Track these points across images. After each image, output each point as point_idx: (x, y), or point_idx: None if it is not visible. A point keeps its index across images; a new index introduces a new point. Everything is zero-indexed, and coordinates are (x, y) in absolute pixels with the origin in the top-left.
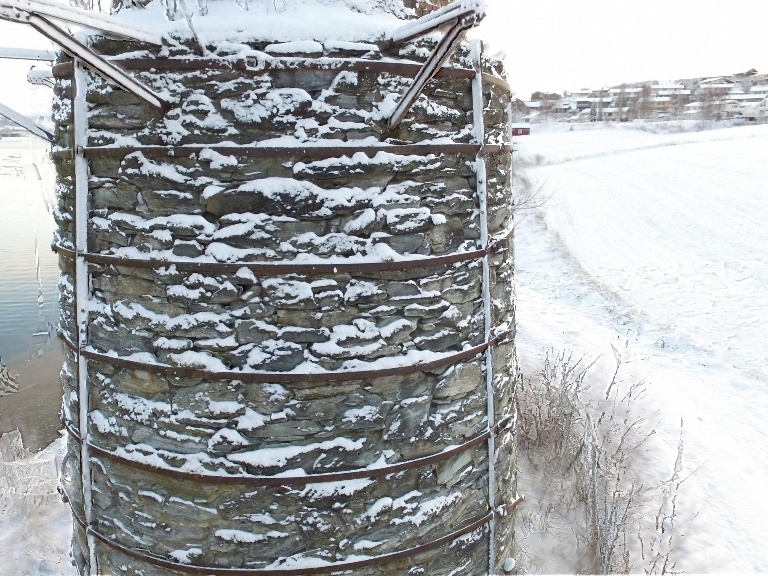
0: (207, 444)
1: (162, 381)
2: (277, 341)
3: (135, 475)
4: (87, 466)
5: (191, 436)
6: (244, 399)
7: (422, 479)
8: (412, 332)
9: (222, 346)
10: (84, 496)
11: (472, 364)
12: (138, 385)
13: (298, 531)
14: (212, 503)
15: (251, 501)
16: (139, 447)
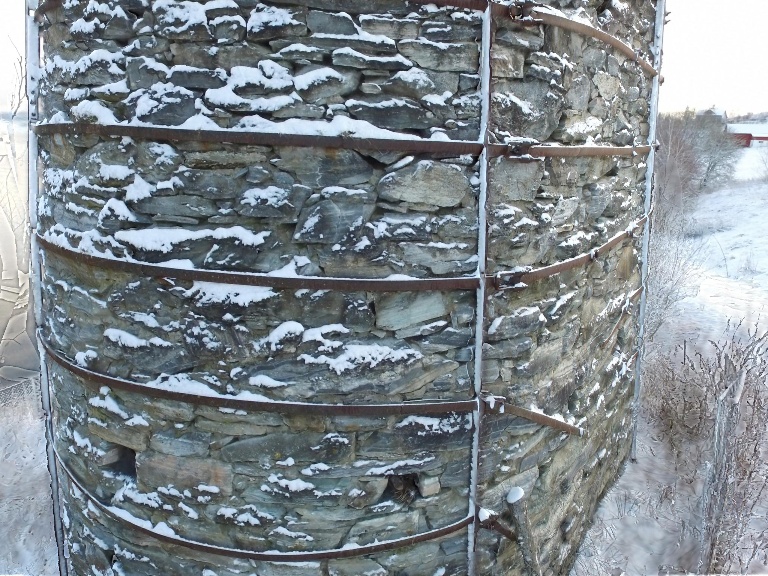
0: (98, 218)
1: (69, 144)
2: (165, 84)
3: (58, 264)
4: (37, 259)
5: (86, 208)
6: (134, 163)
7: (350, 309)
8: (348, 95)
9: (113, 92)
10: (34, 292)
11: (450, 167)
12: (61, 156)
13: (183, 343)
14: (106, 296)
15: (134, 294)
16: (56, 227)
